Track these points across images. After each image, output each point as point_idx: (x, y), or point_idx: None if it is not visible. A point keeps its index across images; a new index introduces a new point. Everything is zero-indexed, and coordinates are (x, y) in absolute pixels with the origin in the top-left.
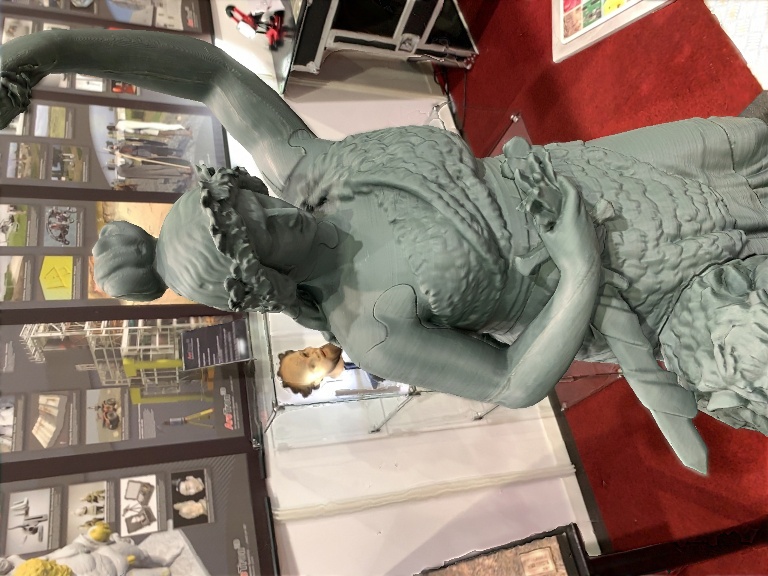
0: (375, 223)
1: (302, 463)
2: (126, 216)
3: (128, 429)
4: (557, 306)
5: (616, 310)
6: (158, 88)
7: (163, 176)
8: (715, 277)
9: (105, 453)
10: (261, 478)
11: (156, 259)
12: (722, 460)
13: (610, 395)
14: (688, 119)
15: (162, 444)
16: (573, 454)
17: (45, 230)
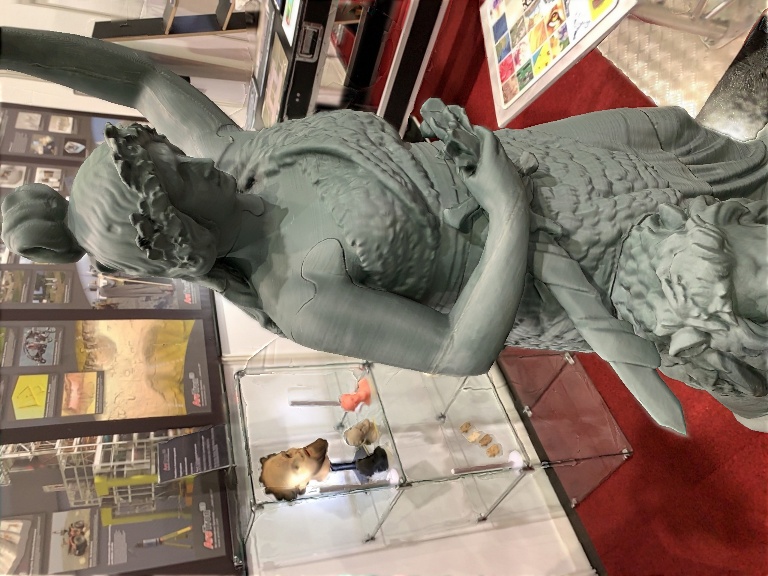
0: (300, 188)
1: None
2: (106, 333)
3: (96, 554)
4: (490, 249)
5: (554, 256)
6: (88, 88)
7: (145, 294)
8: (652, 221)
9: None
10: None
11: (67, 215)
12: (750, 534)
13: (619, 481)
14: None
15: (134, 570)
16: (592, 557)
17: (22, 350)
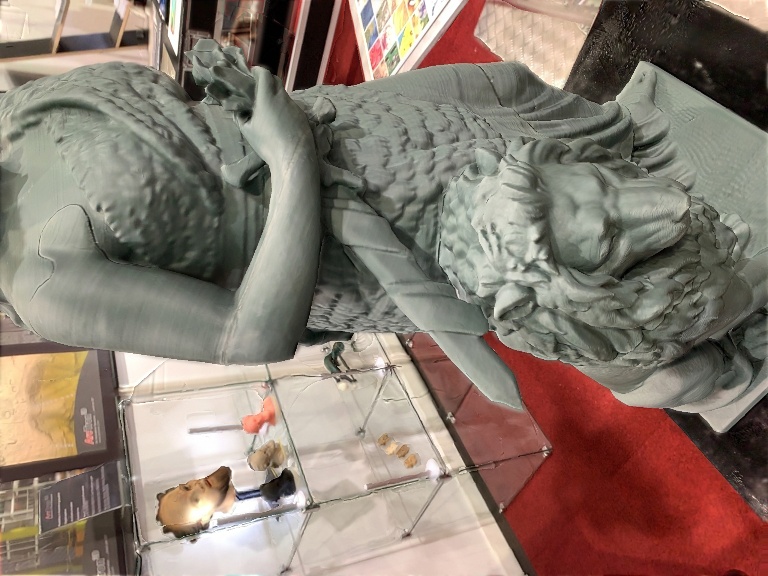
0: (42, 150)
1: None
2: None
3: None
4: (272, 207)
5: (356, 213)
6: None
7: None
8: (470, 169)
9: None
10: None
11: None
12: (667, 520)
13: (542, 480)
14: None
15: None
16: (523, 562)
17: None
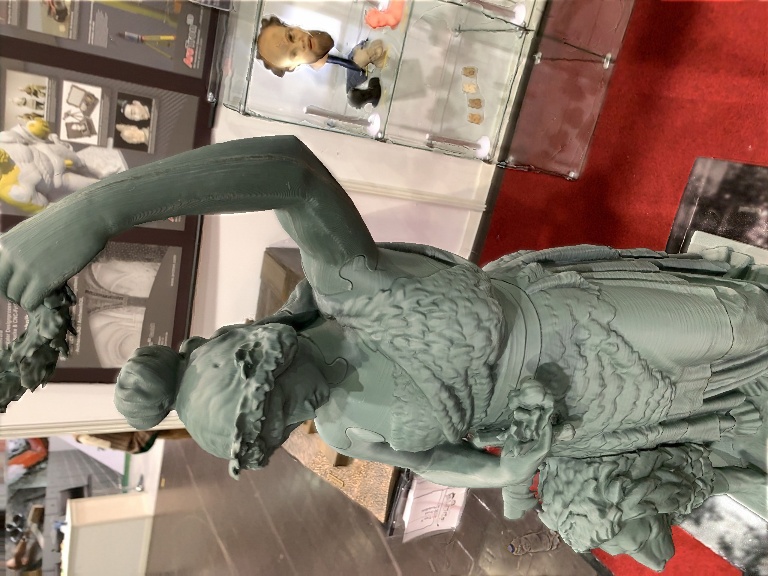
0: (382, 385)
1: (251, 123)
2: None
3: (77, 28)
4: (483, 475)
5: None
6: None
7: None
8: (607, 473)
9: (49, 47)
10: (208, 127)
11: (176, 404)
12: None
13: (550, 183)
14: (718, 316)
15: (113, 57)
16: (491, 198)
17: None
